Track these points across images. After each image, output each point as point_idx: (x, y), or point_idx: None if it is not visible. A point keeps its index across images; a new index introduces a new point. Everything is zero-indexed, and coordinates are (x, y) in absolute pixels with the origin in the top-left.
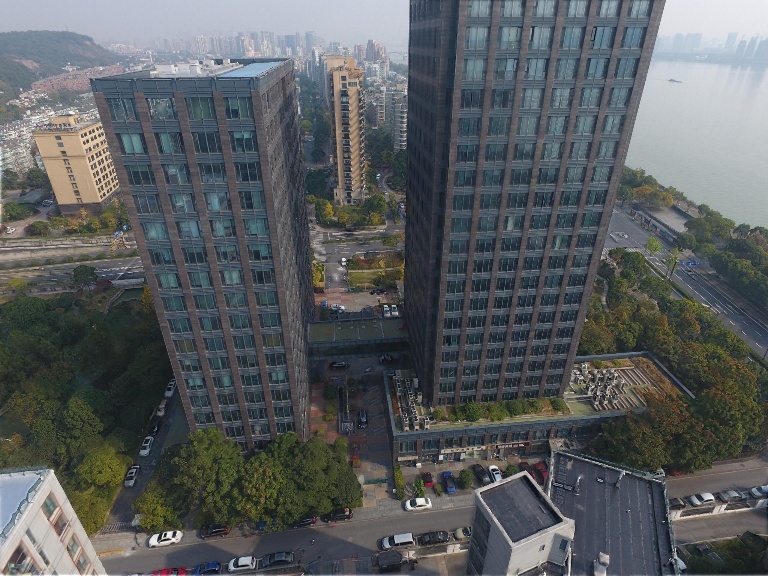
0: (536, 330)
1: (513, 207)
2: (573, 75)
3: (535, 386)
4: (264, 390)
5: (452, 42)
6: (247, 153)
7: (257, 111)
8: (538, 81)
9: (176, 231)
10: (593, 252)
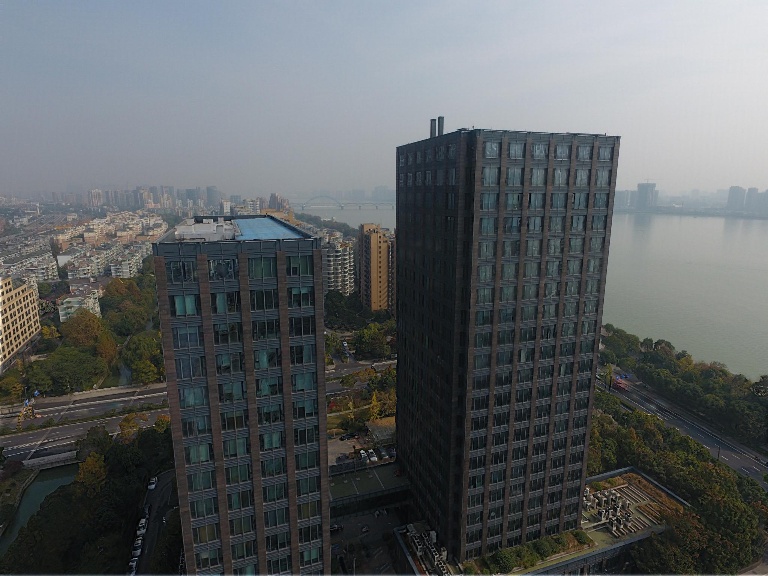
0: (551, 459)
1: (524, 341)
2: (561, 229)
3: (555, 520)
4: (293, 575)
5: (467, 205)
6: (303, 308)
7: (317, 268)
8: (537, 234)
9: (217, 395)
10: (591, 376)
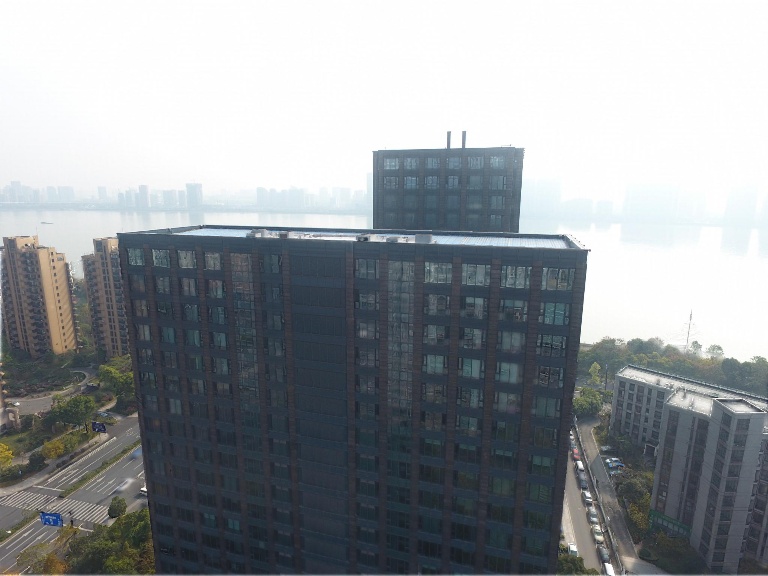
0: None
1: None
2: None
3: None
4: None
5: (512, 205)
6: None
7: None
8: None
9: None
10: None
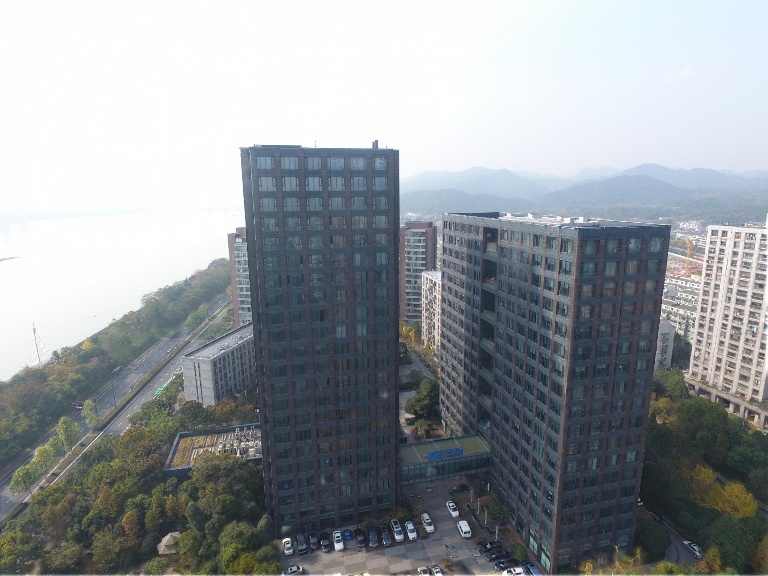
0: None
1: None
2: None
3: None
4: None
5: None
6: None
7: None
8: None
9: None
10: None
